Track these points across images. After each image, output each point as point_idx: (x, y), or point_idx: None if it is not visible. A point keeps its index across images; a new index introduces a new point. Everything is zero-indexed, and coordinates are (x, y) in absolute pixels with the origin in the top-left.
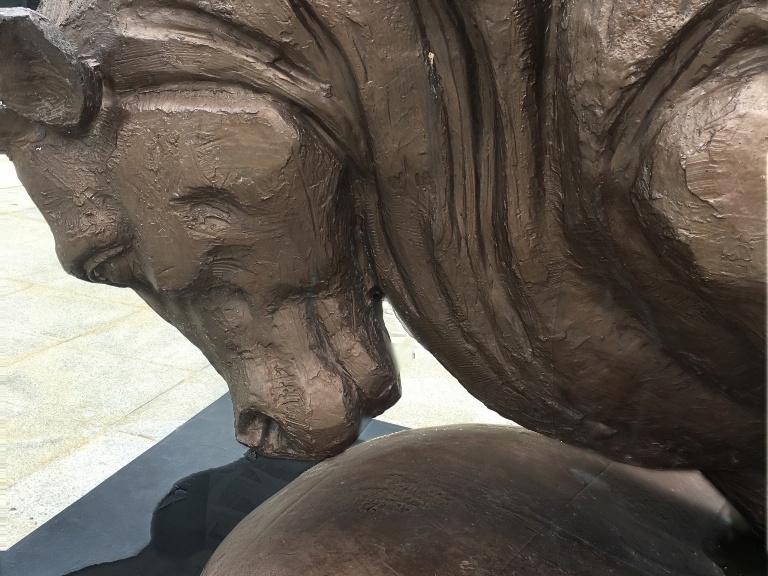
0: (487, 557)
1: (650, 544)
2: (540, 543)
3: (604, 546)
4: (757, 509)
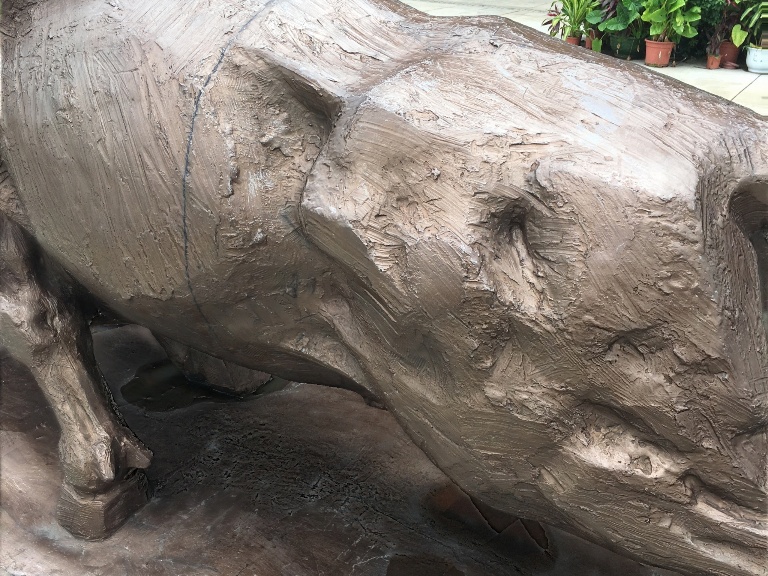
0: None
1: None
2: None
3: None
4: (165, 348)
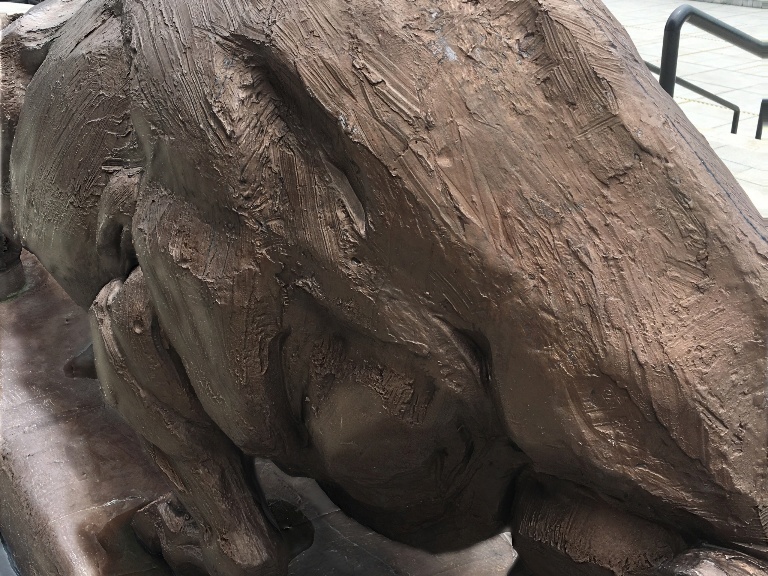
0: (482, 569)
1: (328, 575)
2: (432, 572)
3: (380, 568)
4: None
